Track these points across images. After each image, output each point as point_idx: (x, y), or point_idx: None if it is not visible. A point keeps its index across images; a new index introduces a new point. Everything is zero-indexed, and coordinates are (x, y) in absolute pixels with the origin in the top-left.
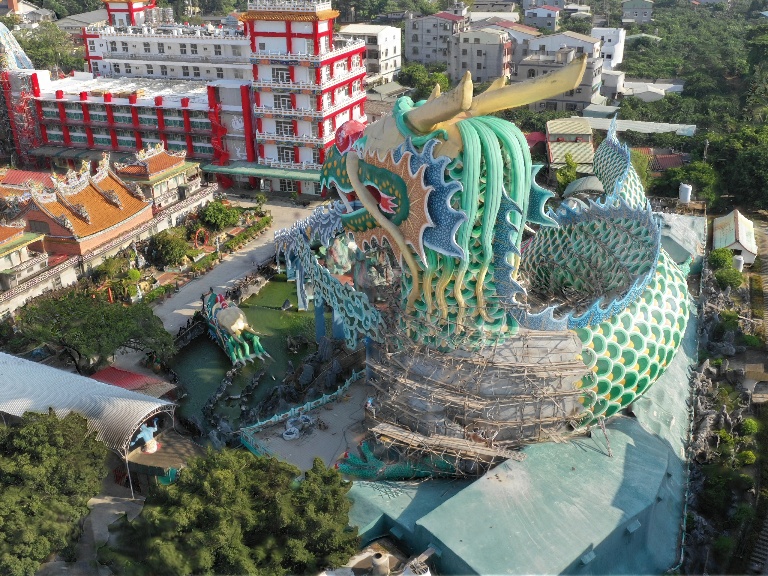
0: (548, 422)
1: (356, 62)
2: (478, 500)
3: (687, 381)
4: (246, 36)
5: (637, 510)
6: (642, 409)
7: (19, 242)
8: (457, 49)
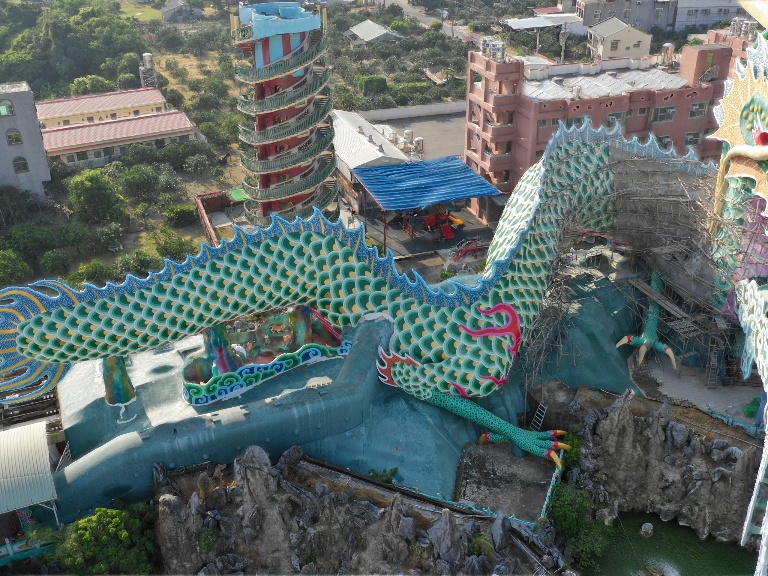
0: None
1: None
2: None
3: None
4: None
5: None
6: None
7: None
8: None
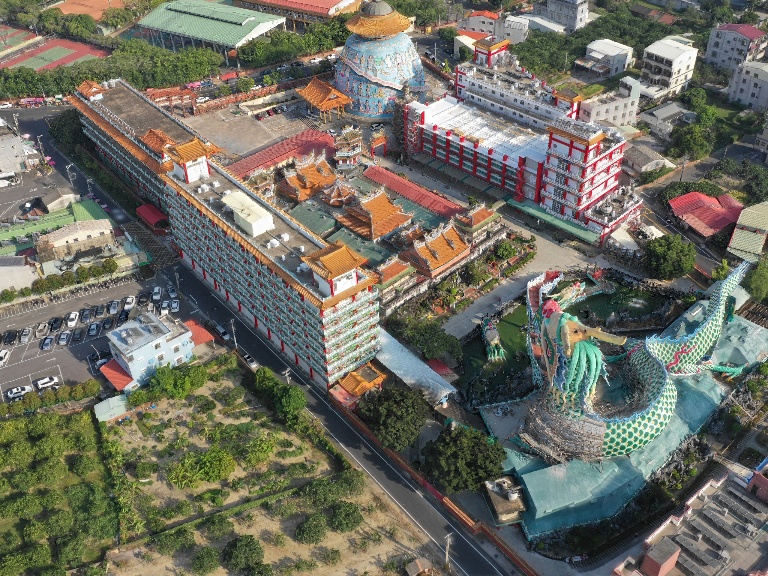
0: (585, 453)
1: (617, 151)
2: (545, 475)
3: (679, 442)
4: (556, 105)
5: (597, 496)
6: (637, 454)
7: (406, 273)
8: (739, 77)
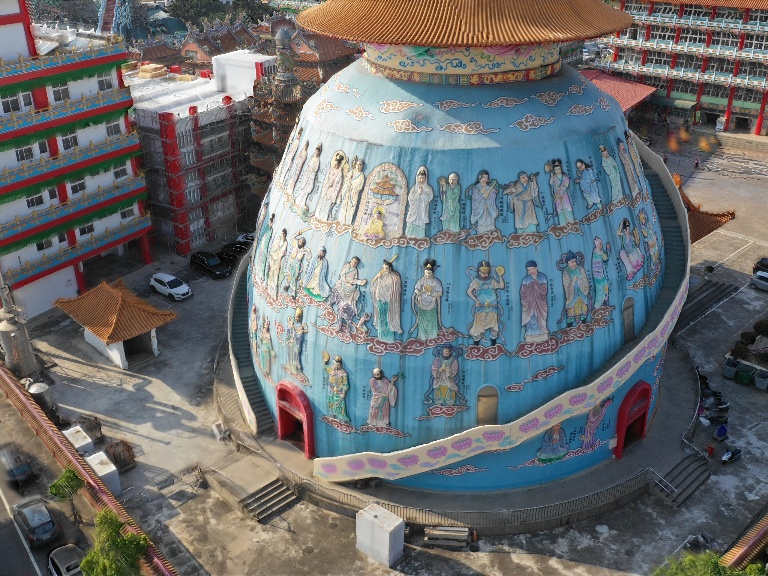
0: None
1: None
2: None
3: None
4: None
5: None
6: None
7: None
8: None
